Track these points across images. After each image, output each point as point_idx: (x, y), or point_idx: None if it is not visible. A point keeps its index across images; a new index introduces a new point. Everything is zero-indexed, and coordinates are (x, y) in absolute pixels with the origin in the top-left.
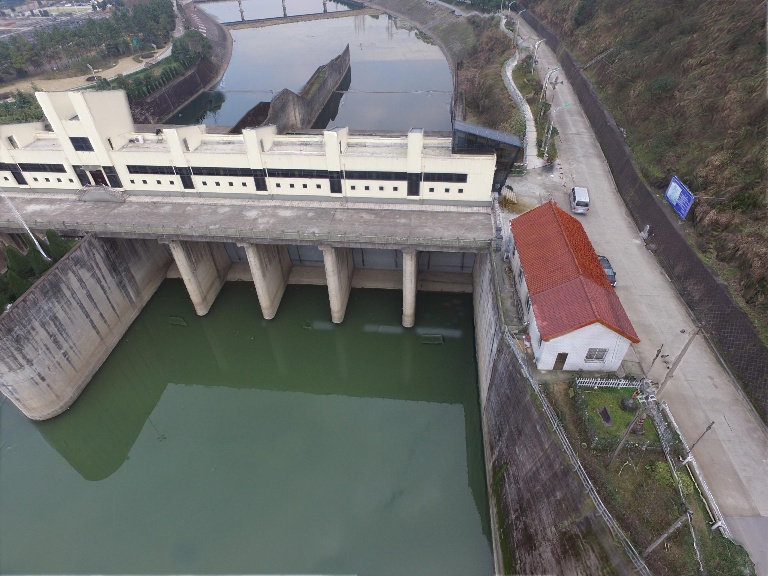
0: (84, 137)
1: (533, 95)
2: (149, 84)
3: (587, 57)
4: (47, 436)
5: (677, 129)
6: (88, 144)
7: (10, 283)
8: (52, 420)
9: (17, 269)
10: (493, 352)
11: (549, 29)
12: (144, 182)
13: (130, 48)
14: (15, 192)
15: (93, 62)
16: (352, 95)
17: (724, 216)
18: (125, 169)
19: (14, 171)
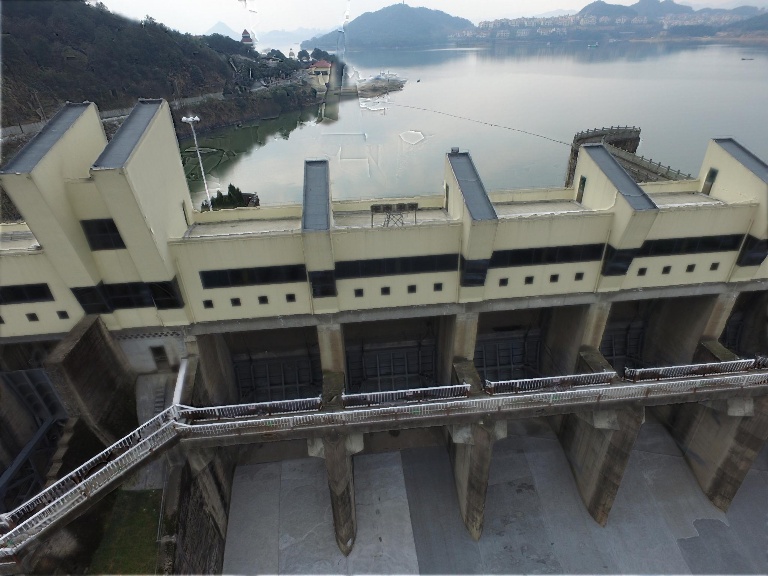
0: None
1: None
2: None
3: None
4: None
5: None
6: None
7: None
8: None
9: None
10: None
11: None
12: None
13: None
14: None
15: None
16: None
17: None
18: None
19: None
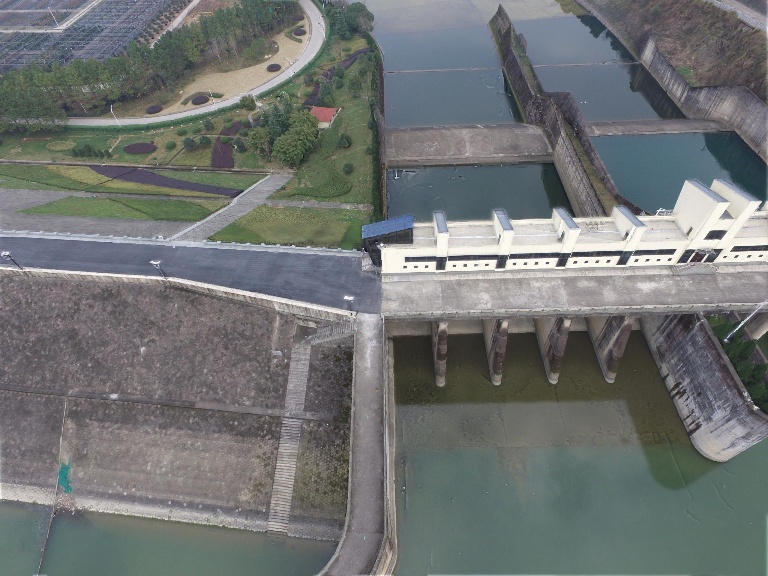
0: (722, 230)
1: None
2: (375, 81)
3: None
4: (734, 473)
5: None
6: (719, 234)
7: (759, 371)
8: (728, 460)
9: (737, 356)
10: None
11: (767, 0)
12: (735, 257)
13: (280, 24)
14: (605, 270)
15: (260, 47)
16: (538, 70)
17: None
18: (730, 249)
19: (623, 256)
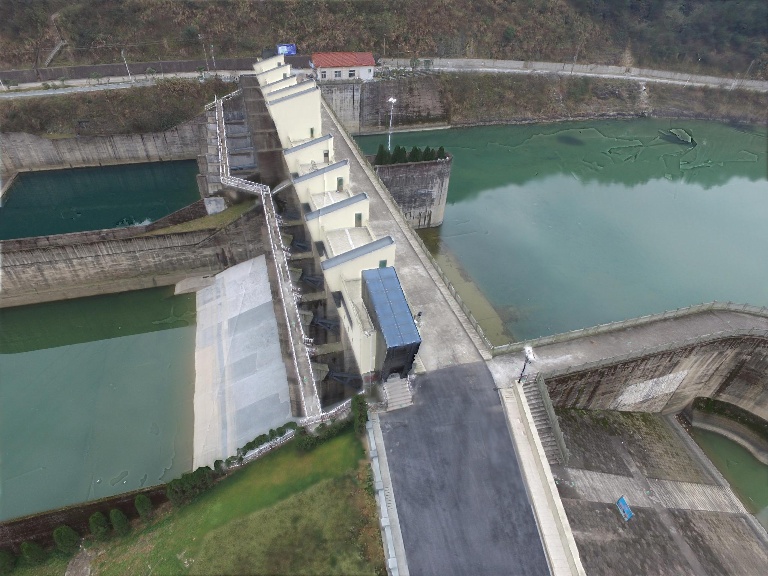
0: None
1: (108, 78)
2: None
3: (5, 65)
4: None
5: (242, 37)
6: None
7: None
8: None
9: None
10: (357, 99)
11: None
12: None
13: None
14: None
15: None
16: None
17: (307, 43)
18: None
19: None
